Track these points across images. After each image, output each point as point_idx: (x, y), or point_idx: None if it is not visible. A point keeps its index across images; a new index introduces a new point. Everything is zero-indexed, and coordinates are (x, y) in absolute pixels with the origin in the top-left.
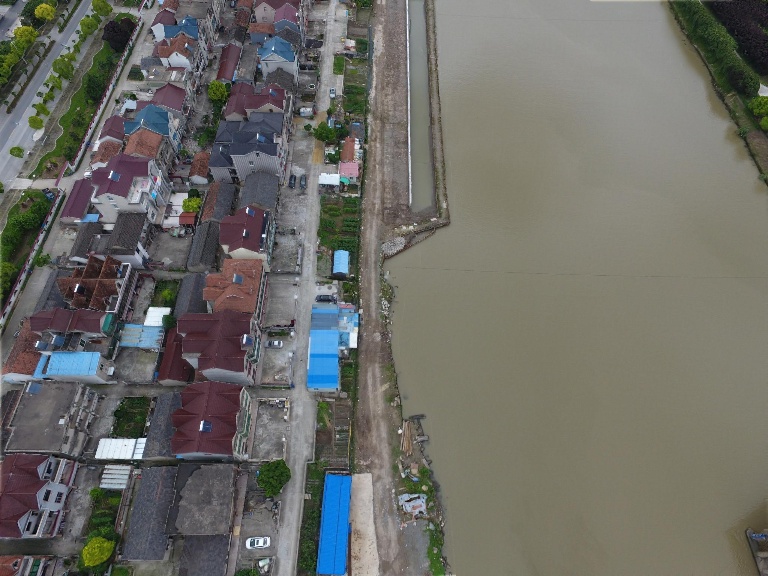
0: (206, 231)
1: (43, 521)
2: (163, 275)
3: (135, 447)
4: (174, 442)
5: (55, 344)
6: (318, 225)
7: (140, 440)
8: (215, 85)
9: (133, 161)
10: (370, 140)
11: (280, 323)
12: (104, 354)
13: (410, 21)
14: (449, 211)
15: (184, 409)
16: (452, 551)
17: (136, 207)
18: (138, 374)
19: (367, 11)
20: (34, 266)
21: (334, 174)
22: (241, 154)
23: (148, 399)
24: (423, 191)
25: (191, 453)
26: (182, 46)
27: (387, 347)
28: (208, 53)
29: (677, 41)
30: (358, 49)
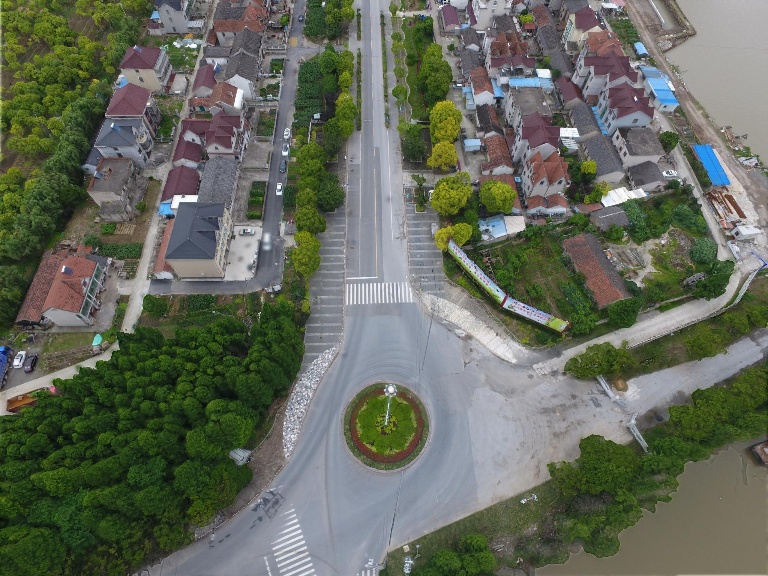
0: (550, 29)
1: None
2: None
3: None
4: (620, 110)
5: (513, 71)
6: None
7: (573, 129)
8: None
9: None
10: None
11: None
12: None
13: None
14: None
15: None
16: None
17: (506, 12)
18: None
19: None
20: None
21: (610, 3)
22: None
23: (560, 114)
24: (665, 19)
25: (631, 115)
26: None
27: None
28: None
29: None
30: None
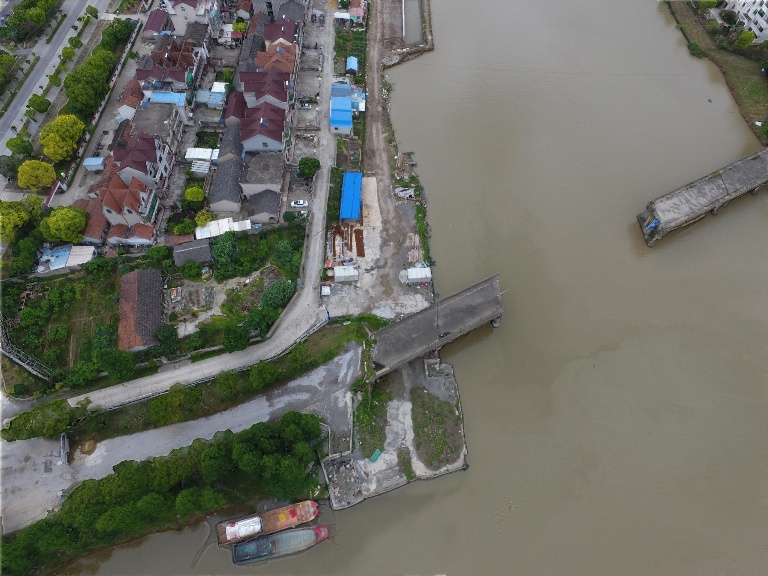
0: (252, 40)
1: (159, 173)
2: None
3: (212, 154)
4: (243, 132)
5: (155, 85)
6: (334, 44)
7: (215, 150)
8: None
9: None
10: None
11: None
12: (187, 98)
13: None
14: (433, 42)
15: None
16: (432, 219)
17: (201, 19)
18: None
19: None
20: (126, 63)
21: (345, 13)
22: None
23: (217, 133)
24: (414, 32)
25: (255, 139)
26: None
27: (386, 115)
28: None
29: None
30: None
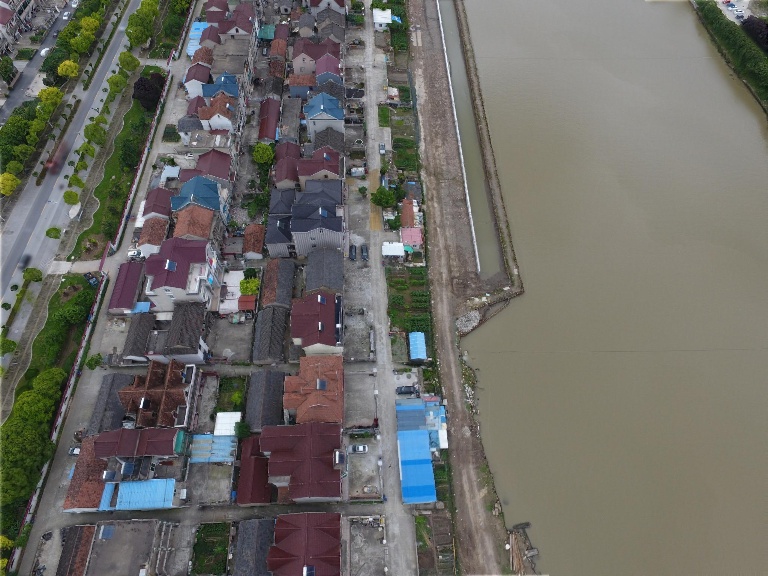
0: (270, 318)
1: None
2: (226, 370)
3: None
4: None
5: (124, 473)
6: (386, 302)
7: None
8: (261, 148)
9: (189, 246)
10: (427, 199)
11: (361, 422)
12: (177, 478)
13: (450, 63)
14: (520, 277)
15: (278, 547)
16: None
17: (194, 297)
18: (212, 493)
19: (404, 54)
20: (83, 366)
21: (397, 243)
22: (303, 231)
23: (227, 524)
24: (489, 255)
25: None
26: (223, 107)
27: (478, 443)
28: (246, 109)
29: (724, 76)
30: (401, 97)
